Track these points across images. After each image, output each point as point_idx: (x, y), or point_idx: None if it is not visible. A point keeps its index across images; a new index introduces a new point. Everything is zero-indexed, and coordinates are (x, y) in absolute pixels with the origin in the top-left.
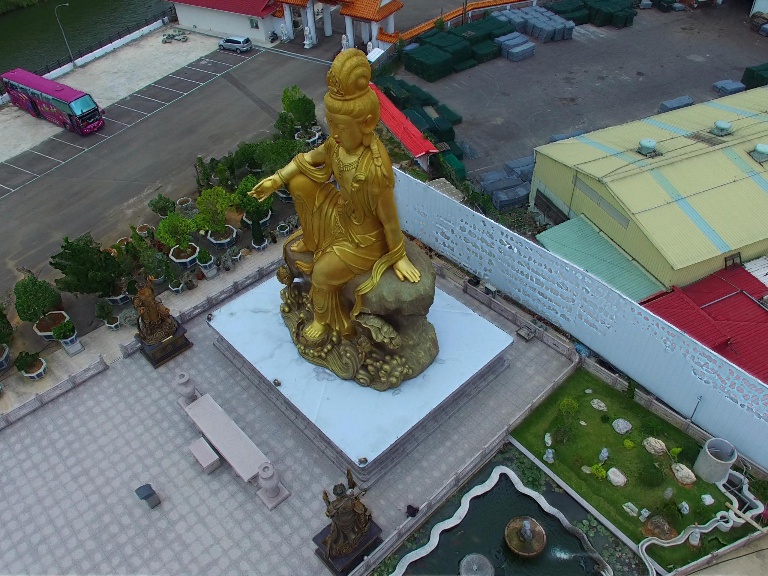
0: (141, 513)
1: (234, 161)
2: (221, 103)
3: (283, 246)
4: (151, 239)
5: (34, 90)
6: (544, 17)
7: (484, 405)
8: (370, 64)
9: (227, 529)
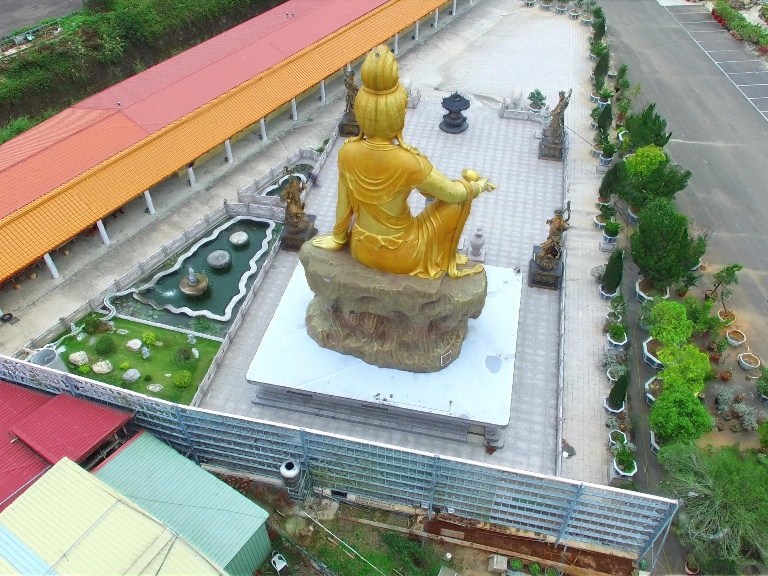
0: None
1: None
2: None
3: None
4: None
5: None
6: None
7: None
8: None
9: None
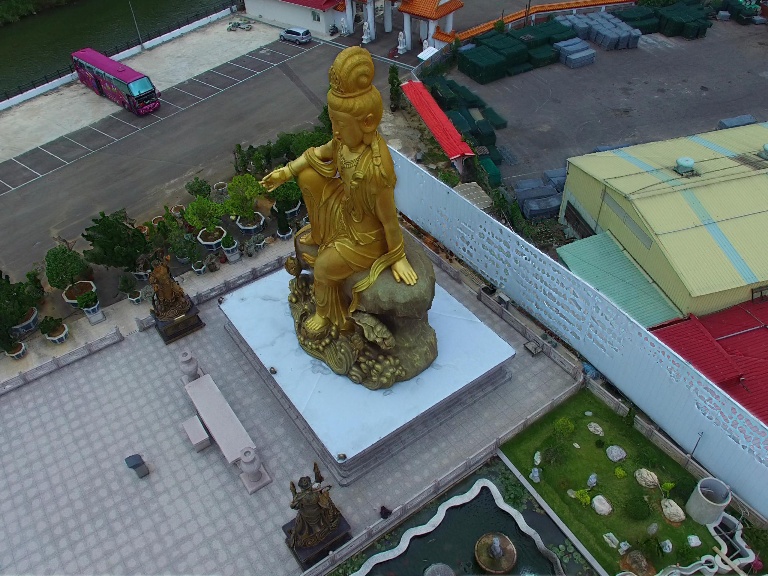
0: (130, 481)
1: (272, 150)
2: (273, 92)
3: None
4: (184, 220)
5: (99, 69)
6: (610, 24)
7: (478, 415)
8: (422, 62)
9: (206, 507)
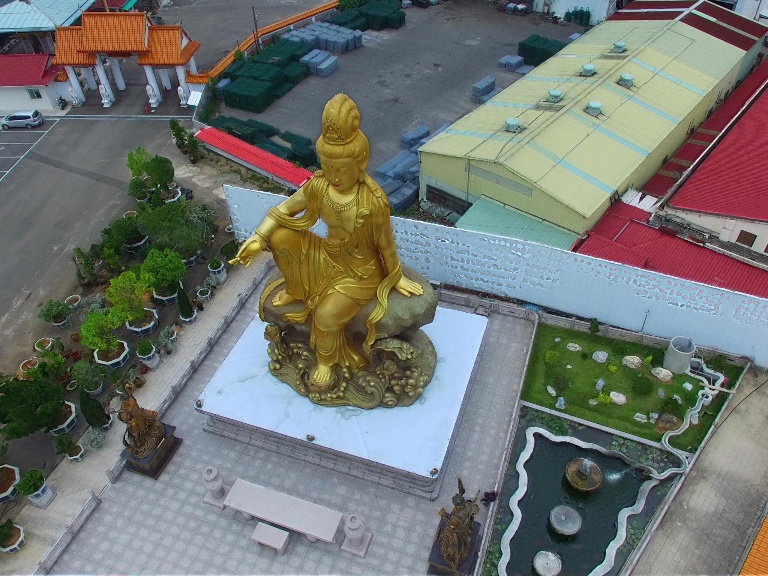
0: None
1: None
2: (44, 186)
3: (260, 305)
4: (60, 352)
5: None
6: (332, 31)
7: (486, 384)
8: (196, 109)
9: None
